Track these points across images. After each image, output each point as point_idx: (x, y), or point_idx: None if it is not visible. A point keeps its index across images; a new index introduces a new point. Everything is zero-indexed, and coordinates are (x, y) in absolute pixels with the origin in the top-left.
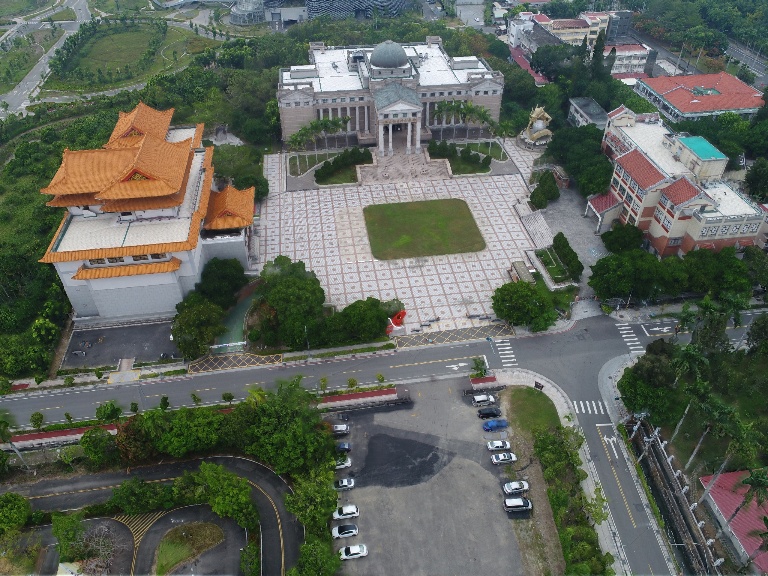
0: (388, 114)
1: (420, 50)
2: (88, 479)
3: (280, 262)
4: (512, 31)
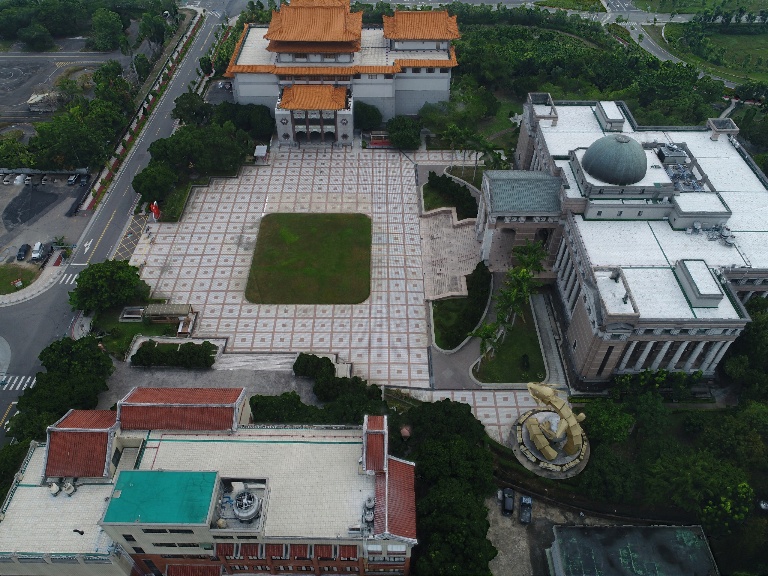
0: None
1: None
2: None
3: None
4: None
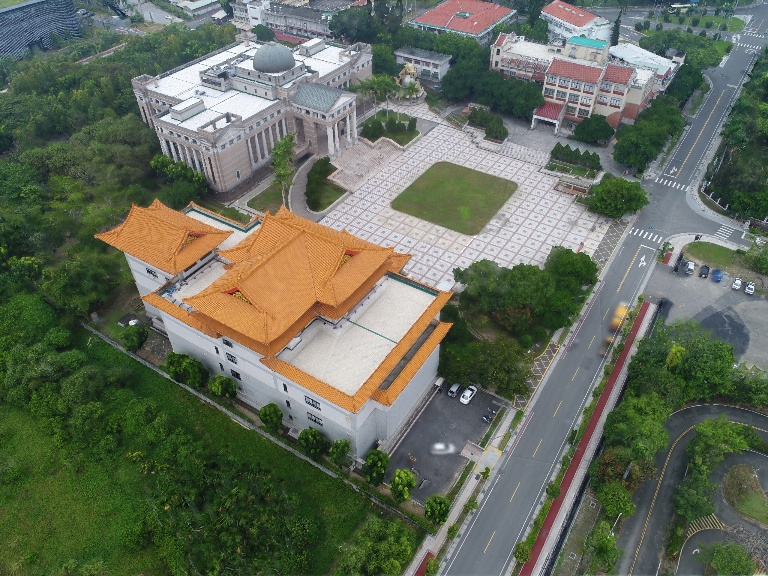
0: (334, 113)
1: None
2: (624, 541)
3: (483, 268)
4: (252, 14)
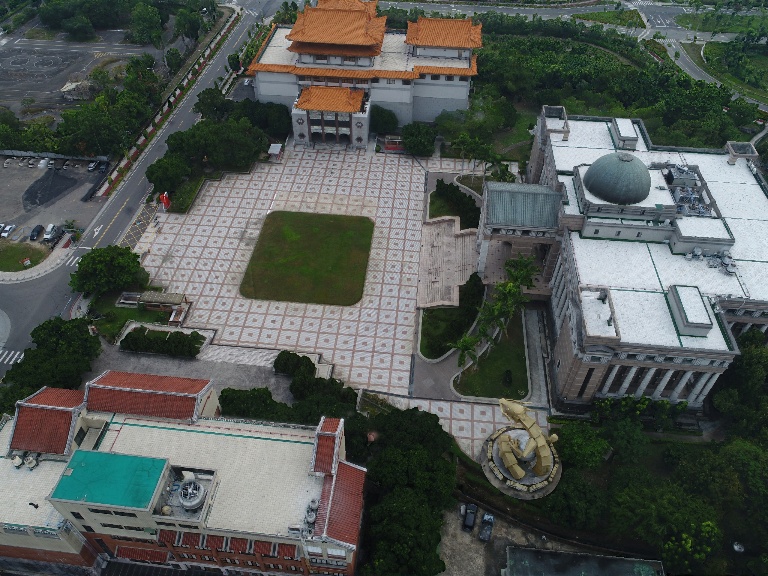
0: None
1: None
2: None
3: None
4: None
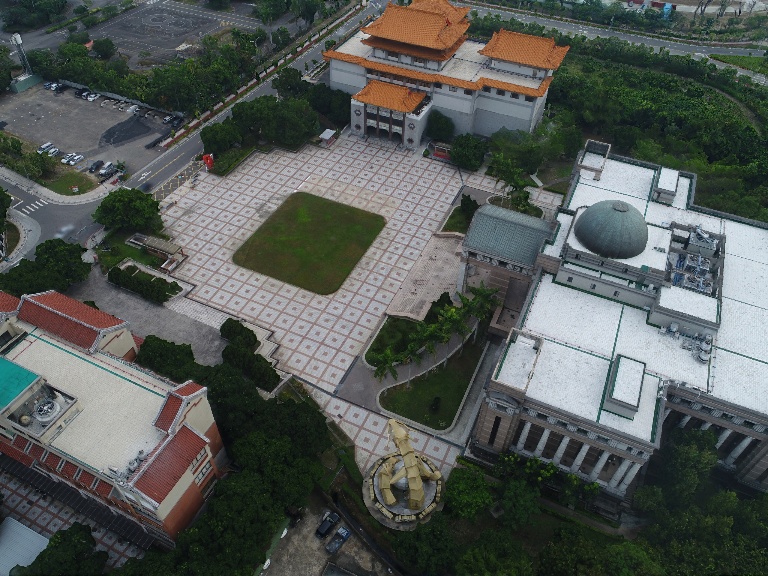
0: None
1: (767, 378)
2: None
3: None
4: None
